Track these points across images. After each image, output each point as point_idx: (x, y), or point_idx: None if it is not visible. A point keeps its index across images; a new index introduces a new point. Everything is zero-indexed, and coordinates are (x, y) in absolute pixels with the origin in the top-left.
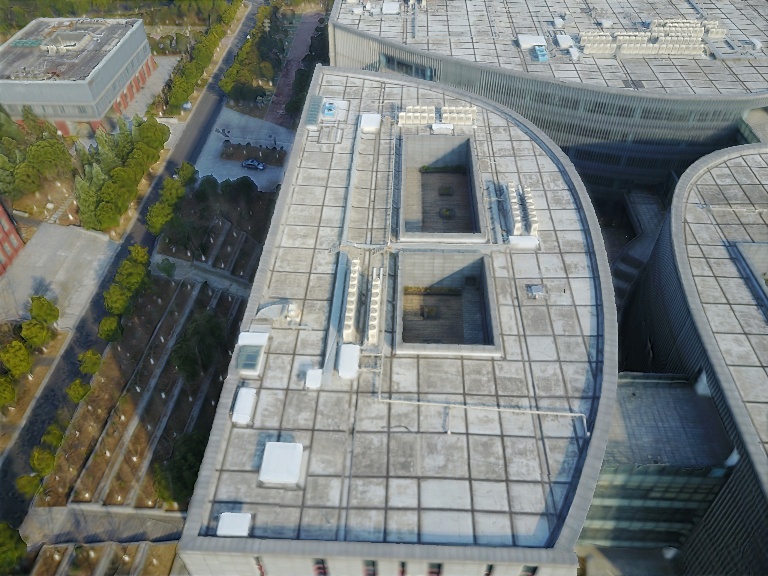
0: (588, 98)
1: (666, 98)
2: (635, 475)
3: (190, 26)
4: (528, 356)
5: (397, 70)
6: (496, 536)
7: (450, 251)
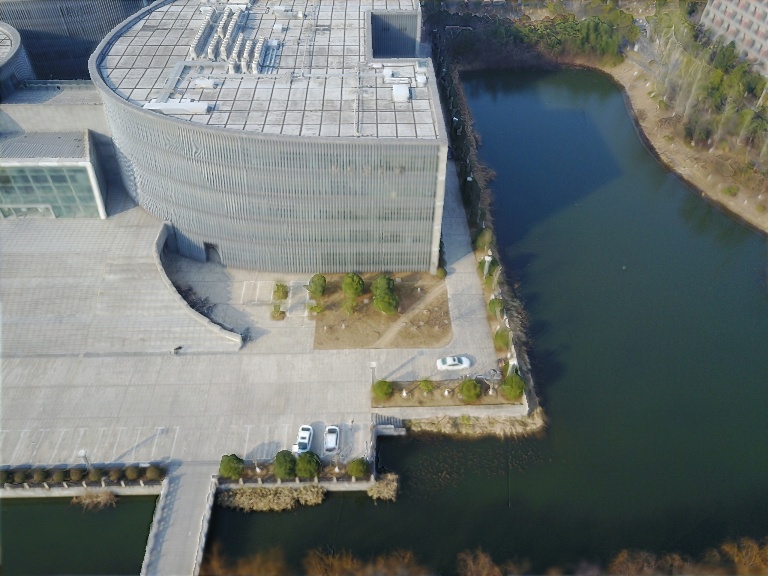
0: None
1: None
2: None
3: None
4: None
5: None
6: None
7: None
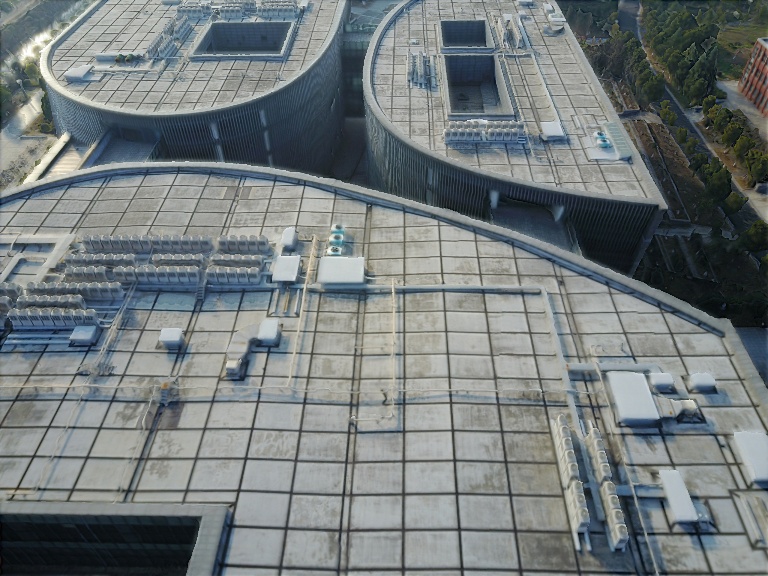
0: None
1: None
2: None
3: None
4: (424, 25)
5: None
6: None
7: None
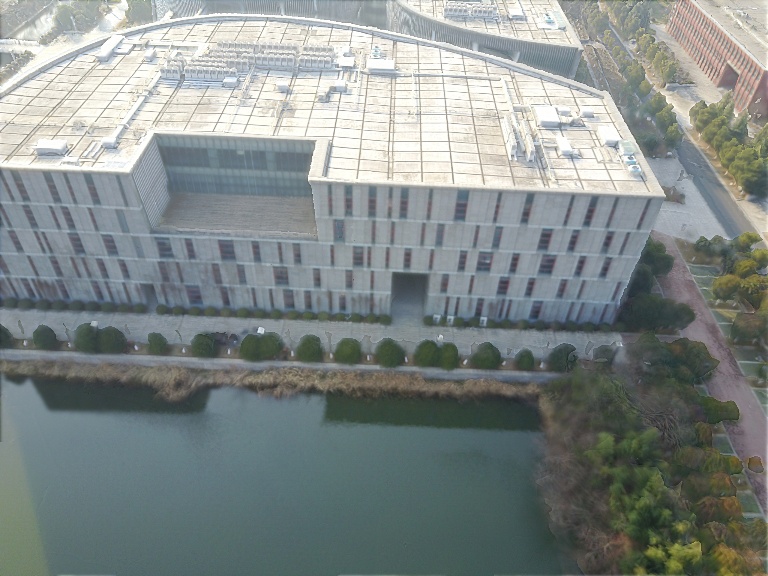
0: None
1: None
2: None
3: None
4: None
5: None
6: None
7: None
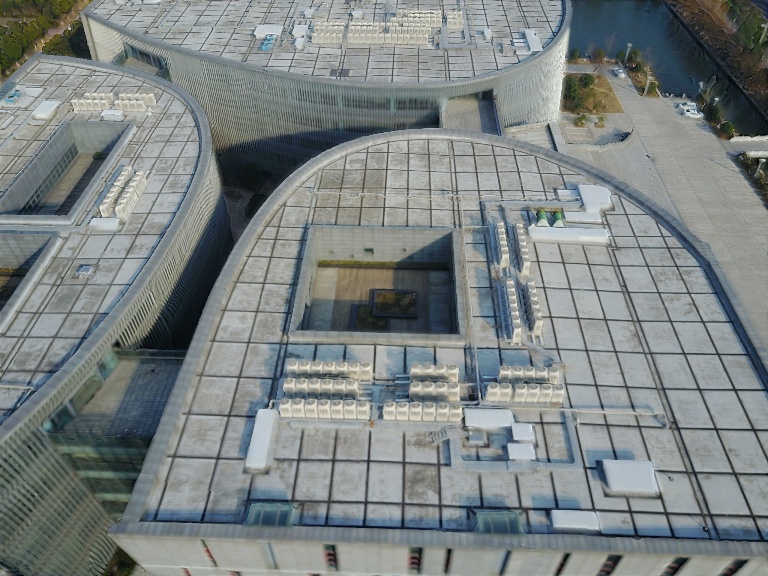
0: (292, 86)
1: (358, 86)
2: (98, 447)
3: (26, 18)
4: (28, 332)
5: (141, 59)
6: None
7: (29, 233)
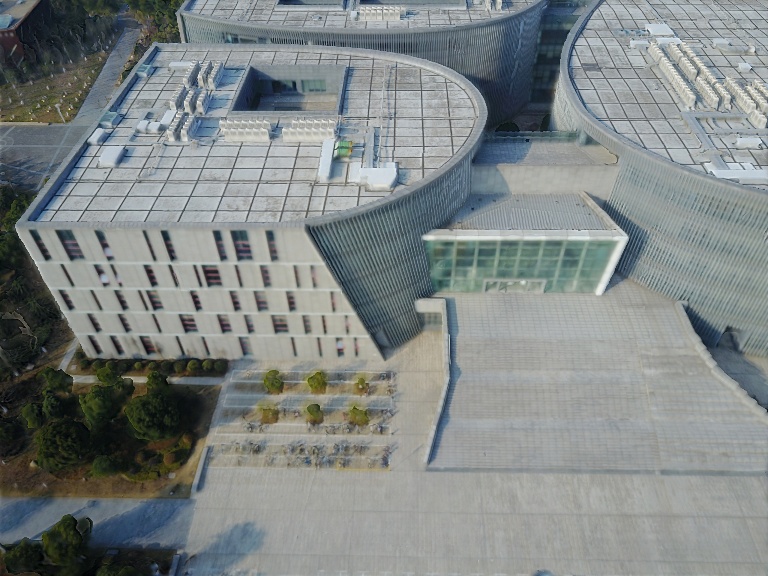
0: None
1: None
2: None
3: None
4: (274, 15)
5: None
6: (194, 7)
7: None
